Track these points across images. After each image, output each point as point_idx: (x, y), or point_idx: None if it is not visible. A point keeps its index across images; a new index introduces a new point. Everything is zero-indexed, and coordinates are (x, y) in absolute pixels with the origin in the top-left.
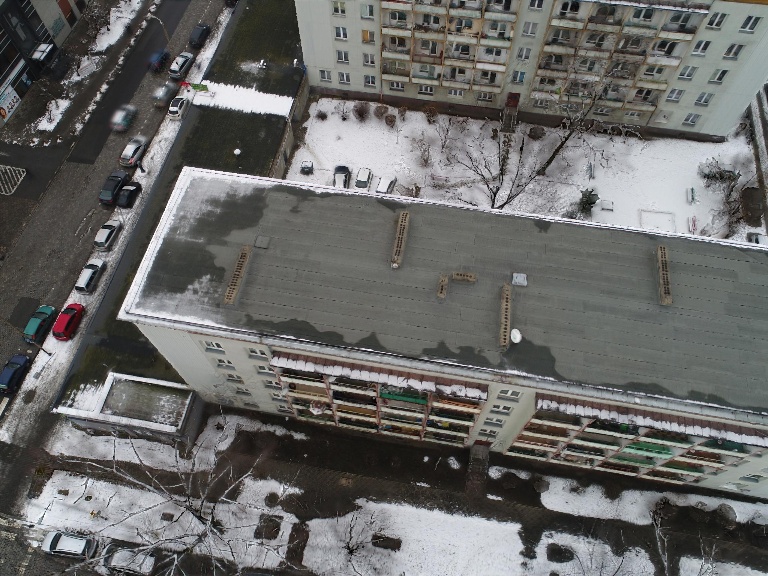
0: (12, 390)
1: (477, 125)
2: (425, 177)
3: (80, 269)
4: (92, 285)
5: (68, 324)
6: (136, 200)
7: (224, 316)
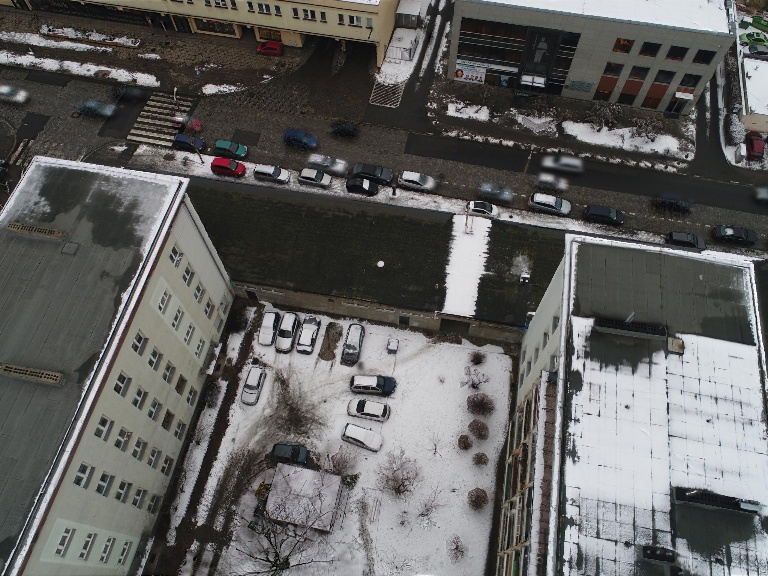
0: (175, 145)
1: (473, 574)
2: (378, 489)
3: (285, 166)
4: (260, 176)
5: (220, 167)
6: (358, 194)
7: (4, 227)
